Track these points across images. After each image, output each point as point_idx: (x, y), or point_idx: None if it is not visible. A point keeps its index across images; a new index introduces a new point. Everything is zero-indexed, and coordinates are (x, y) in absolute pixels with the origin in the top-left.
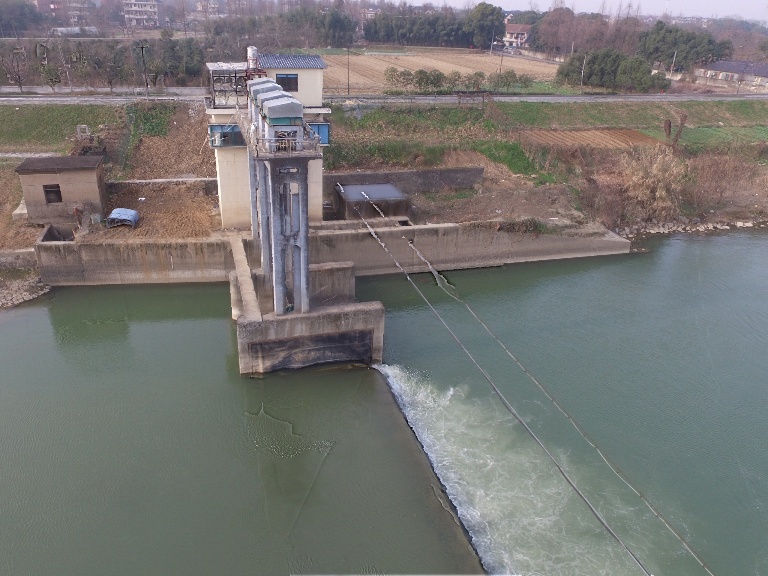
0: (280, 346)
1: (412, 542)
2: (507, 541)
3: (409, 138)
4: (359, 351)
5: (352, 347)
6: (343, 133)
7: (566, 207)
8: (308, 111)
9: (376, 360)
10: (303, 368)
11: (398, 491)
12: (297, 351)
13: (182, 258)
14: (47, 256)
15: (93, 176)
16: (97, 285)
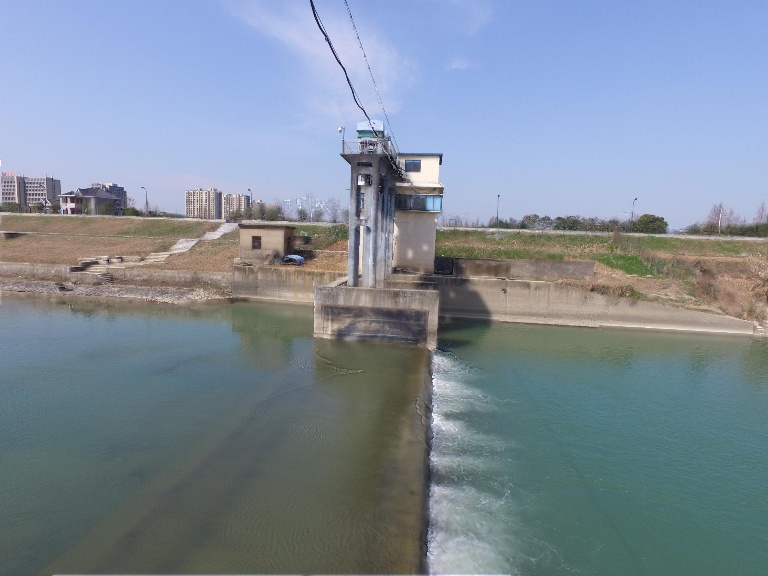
0: (347, 313)
1: (366, 423)
2: (472, 448)
3: (534, 249)
4: (414, 330)
5: (408, 325)
6: (481, 246)
7: (676, 292)
8: (426, 185)
9: (430, 344)
10: (364, 337)
11: (383, 399)
12: (360, 320)
13: (320, 283)
14: (238, 274)
15: (282, 233)
16: (263, 299)
